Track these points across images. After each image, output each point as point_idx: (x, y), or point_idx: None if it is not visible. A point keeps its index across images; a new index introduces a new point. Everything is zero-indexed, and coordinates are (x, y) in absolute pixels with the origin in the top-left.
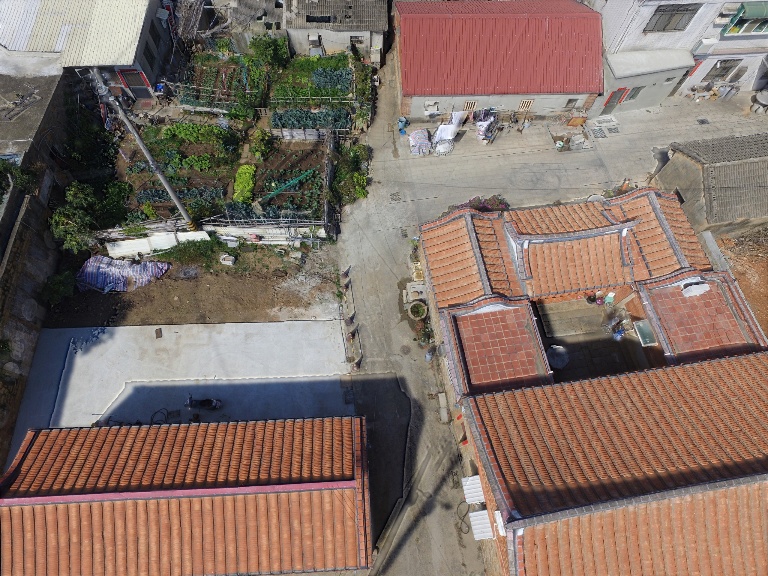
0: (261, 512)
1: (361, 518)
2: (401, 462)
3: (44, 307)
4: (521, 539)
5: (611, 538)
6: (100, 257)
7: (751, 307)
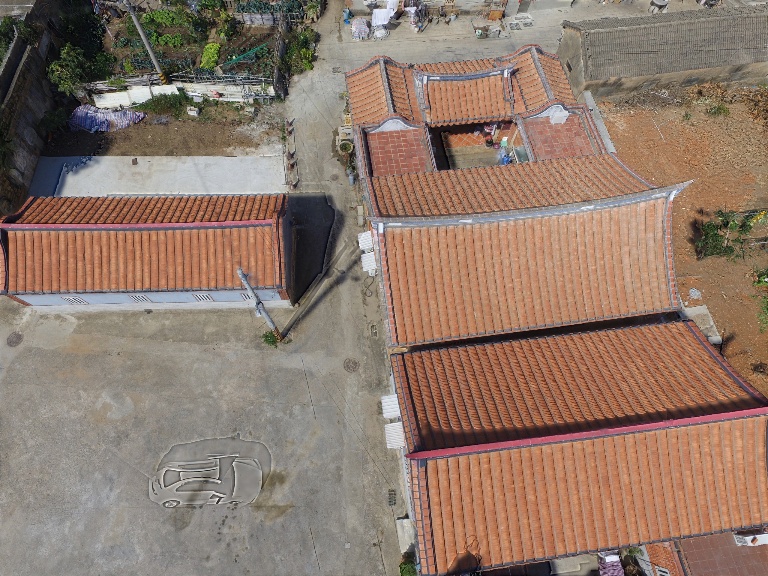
0: (202, 243)
1: (276, 248)
2: (323, 250)
3: (42, 140)
4: (383, 237)
5: (453, 249)
6: (88, 106)
7: (615, 145)
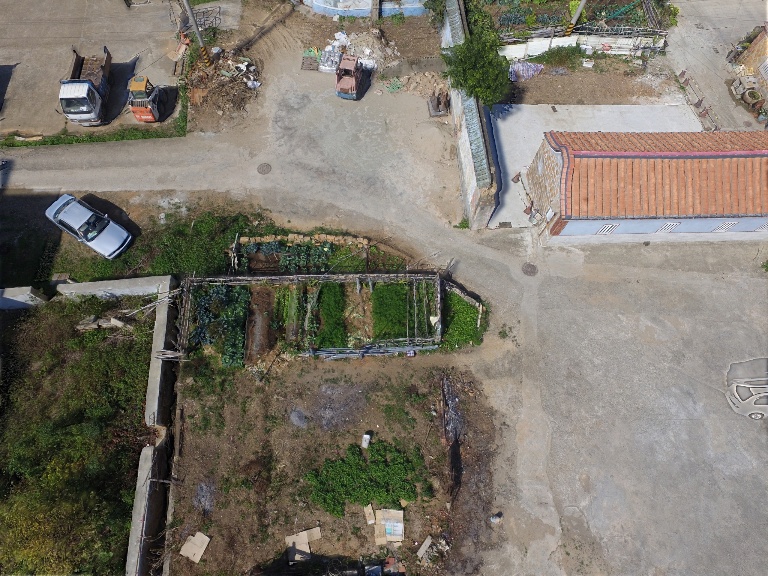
0: (749, 171)
1: None
2: None
3: None
4: None
5: None
6: None
7: None
